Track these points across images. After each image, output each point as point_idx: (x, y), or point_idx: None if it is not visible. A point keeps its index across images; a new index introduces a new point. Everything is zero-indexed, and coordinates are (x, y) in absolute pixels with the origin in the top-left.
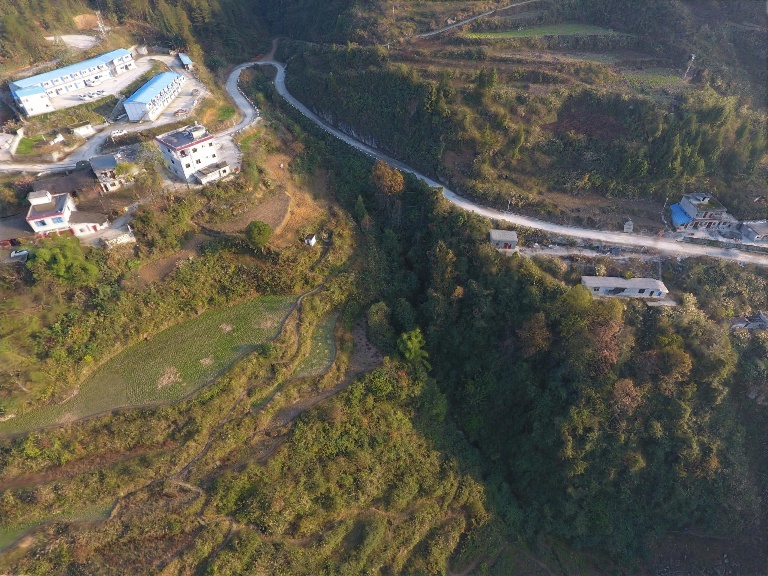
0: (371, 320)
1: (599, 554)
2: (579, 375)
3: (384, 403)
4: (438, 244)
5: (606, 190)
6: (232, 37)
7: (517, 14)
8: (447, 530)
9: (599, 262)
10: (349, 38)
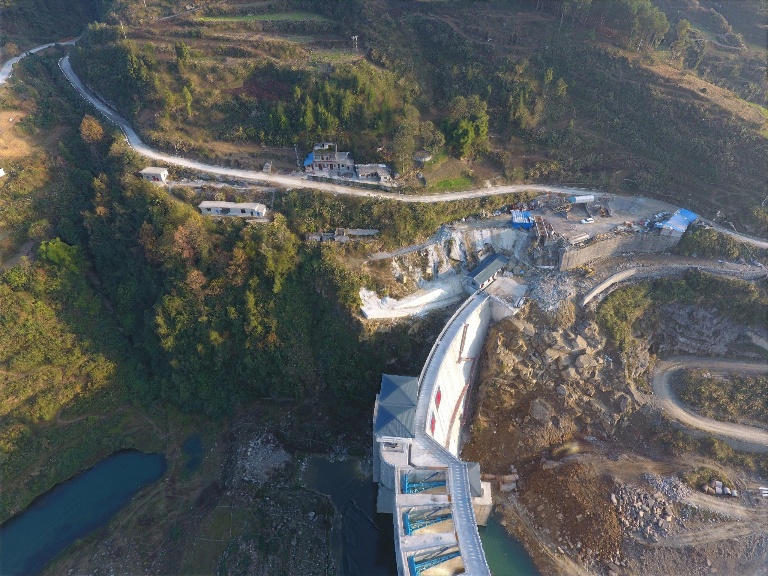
0: (28, 232)
1: (203, 416)
2: (172, 270)
3: (21, 292)
4: (99, 176)
5: (260, 140)
6: (36, 20)
7: (251, 3)
8: (57, 387)
9: (222, 191)
10: (106, 20)
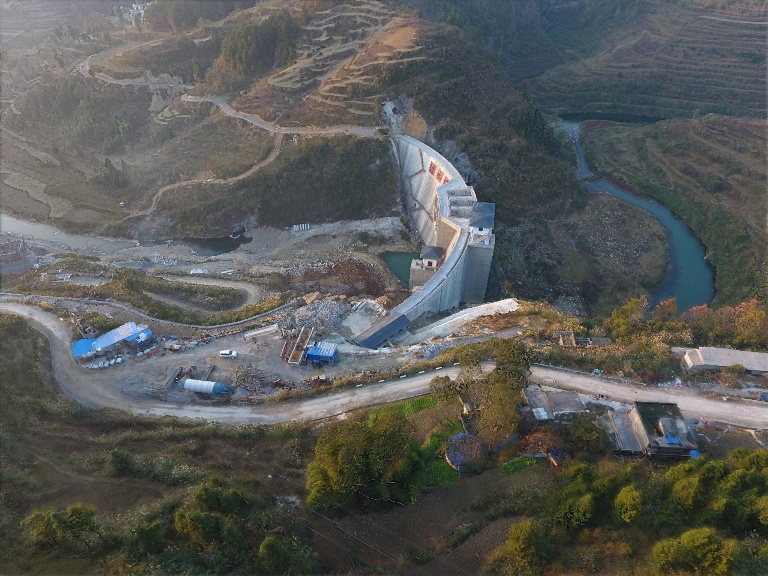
0: None
1: None
2: None
3: None
4: None
5: None
6: None
7: None
8: None
9: None
10: None
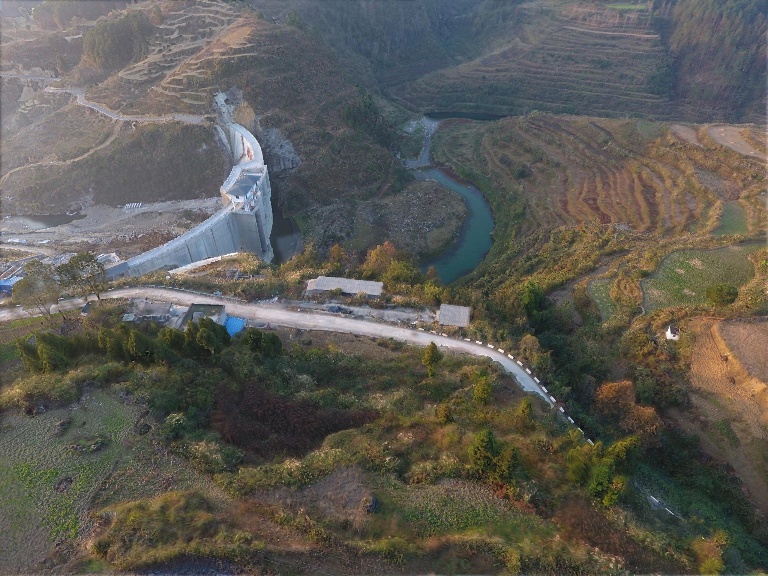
0: None
1: None
2: None
3: None
4: None
5: None
6: None
7: None
8: None
9: None
10: None
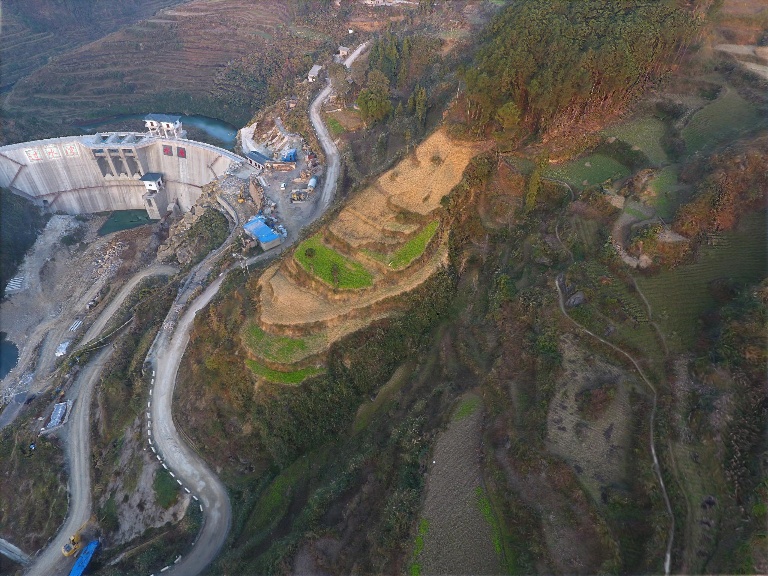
0: None
1: None
2: None
3: None
4: (343, 43)
5: None
6: None
7: None
8: (261, 101)
9: None
10: None
